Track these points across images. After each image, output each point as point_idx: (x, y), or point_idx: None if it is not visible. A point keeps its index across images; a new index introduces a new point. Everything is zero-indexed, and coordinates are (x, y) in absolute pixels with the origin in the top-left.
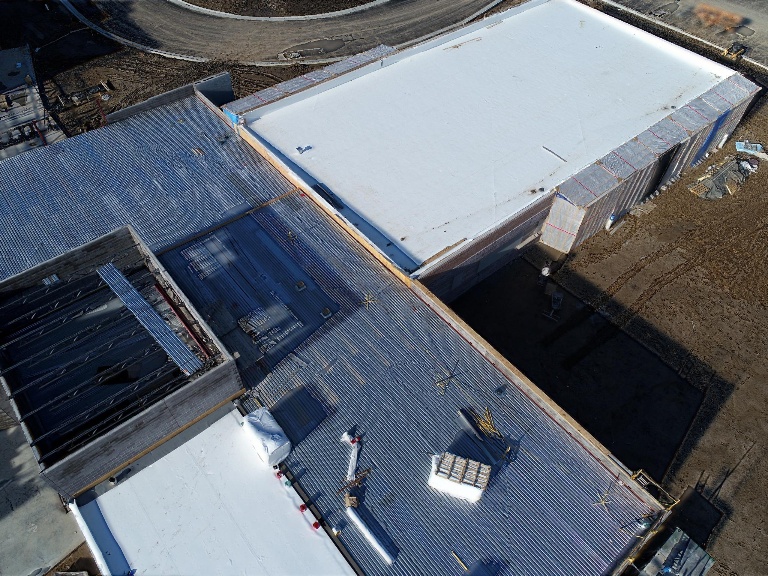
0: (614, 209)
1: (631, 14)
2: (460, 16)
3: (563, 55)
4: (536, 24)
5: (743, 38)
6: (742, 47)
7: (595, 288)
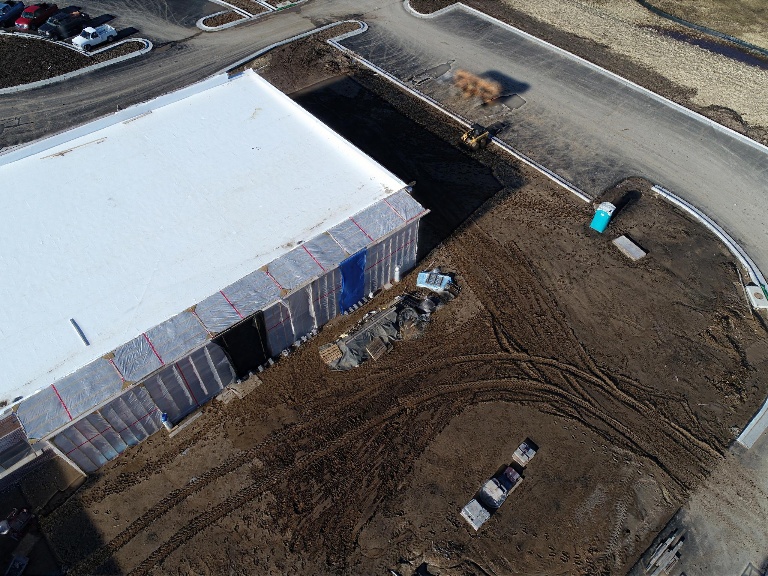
0: (159, 409)
1: (386, 81)
2: (174, 88)
3: (199, 162)
4: (193, 115)
5: (507, 112)
6: (499, 125)
7: (93, 541)
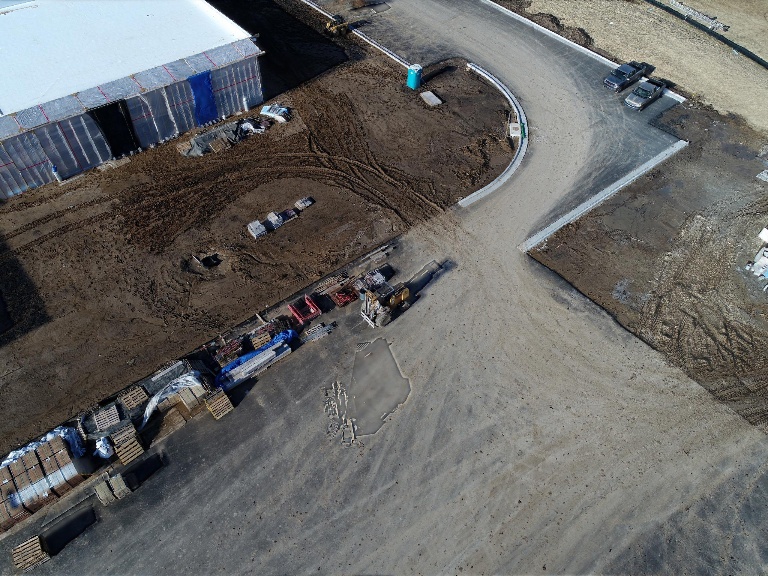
0: (50, 161)
1: None
2: None
3: (105, 22)
4: None
5: (373, 14)
6: (363, 22)
7: None
